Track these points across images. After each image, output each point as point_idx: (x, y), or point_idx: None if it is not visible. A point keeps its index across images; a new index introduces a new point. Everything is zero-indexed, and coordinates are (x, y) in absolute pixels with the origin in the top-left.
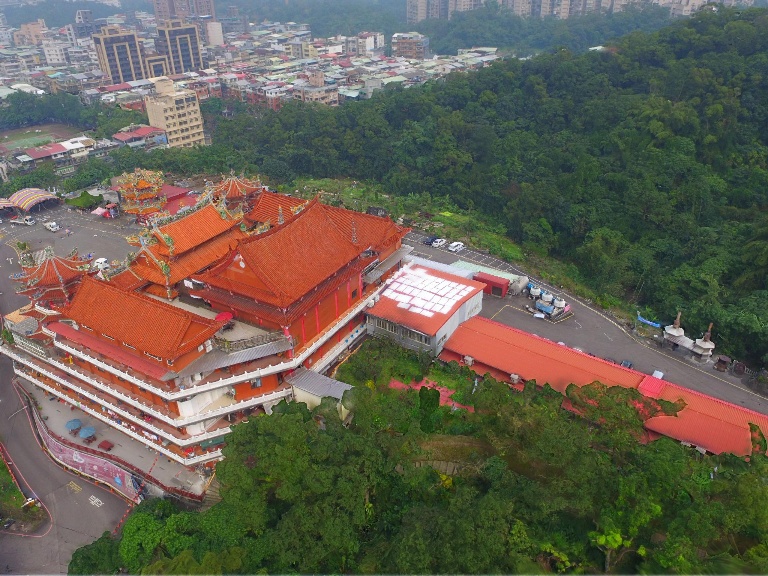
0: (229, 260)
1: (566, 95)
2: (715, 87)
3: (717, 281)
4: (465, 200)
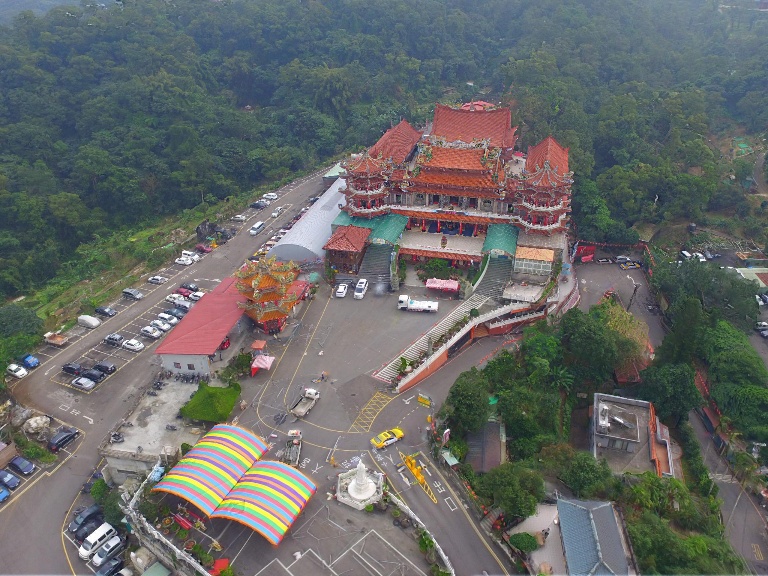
0: None
1: (2, 121)
2: (163, 57)
3: None
4: None
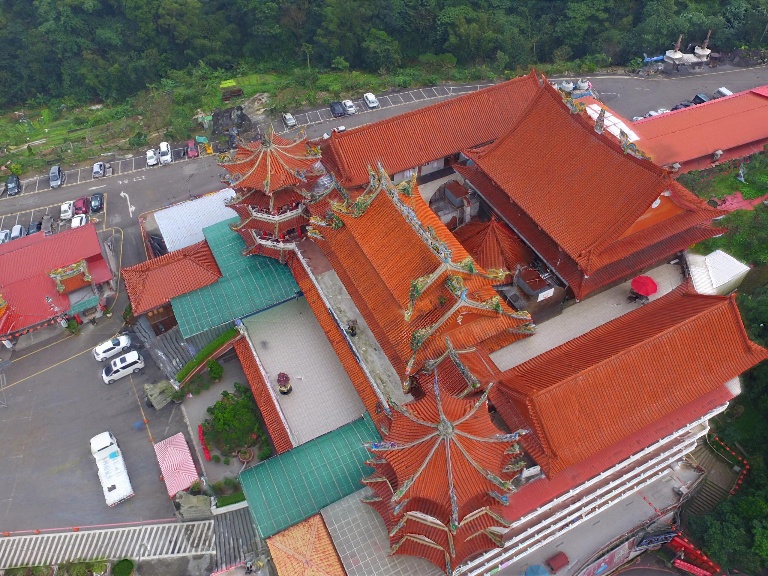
0: (640, 211)
1: None
2: None
3: (616, 4)
4: (223, 58)
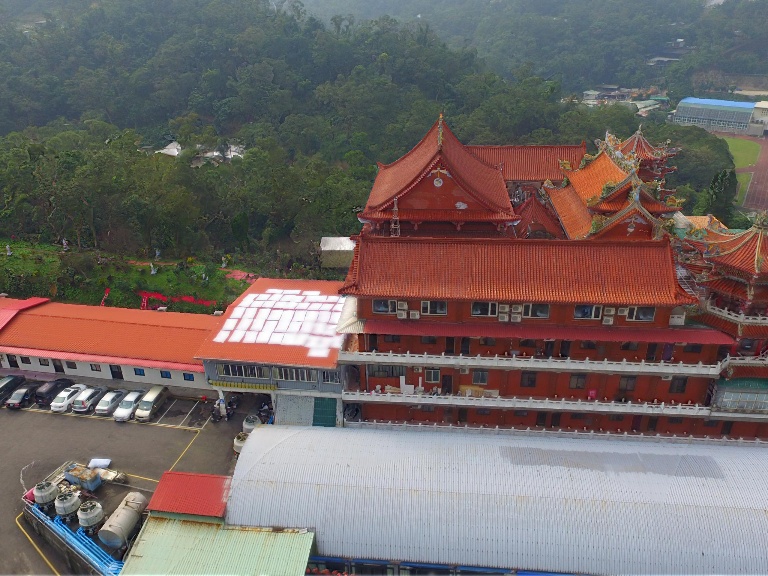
0: None
1: None
2: None
3: None
4: None
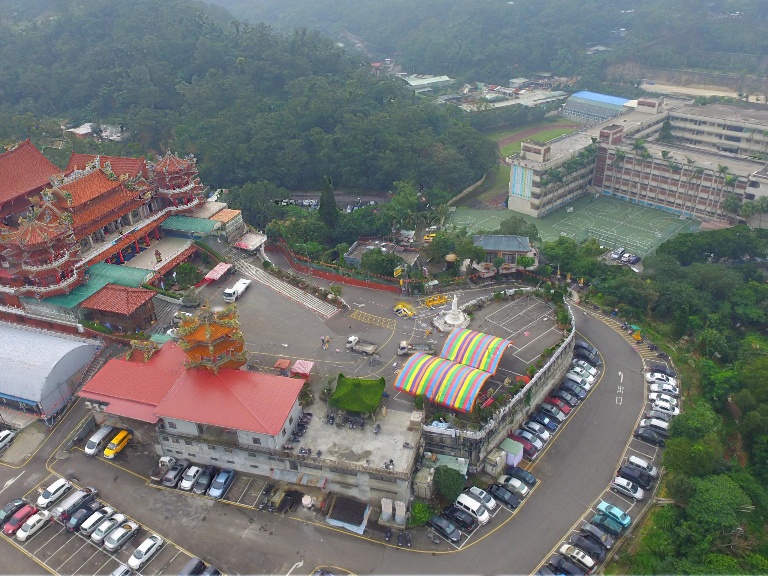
0: None
1: None
2: None
3: None
4: None
